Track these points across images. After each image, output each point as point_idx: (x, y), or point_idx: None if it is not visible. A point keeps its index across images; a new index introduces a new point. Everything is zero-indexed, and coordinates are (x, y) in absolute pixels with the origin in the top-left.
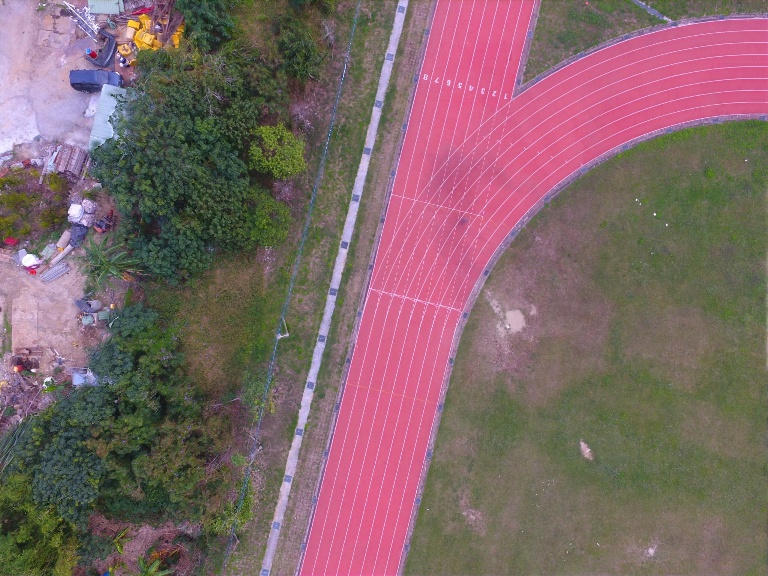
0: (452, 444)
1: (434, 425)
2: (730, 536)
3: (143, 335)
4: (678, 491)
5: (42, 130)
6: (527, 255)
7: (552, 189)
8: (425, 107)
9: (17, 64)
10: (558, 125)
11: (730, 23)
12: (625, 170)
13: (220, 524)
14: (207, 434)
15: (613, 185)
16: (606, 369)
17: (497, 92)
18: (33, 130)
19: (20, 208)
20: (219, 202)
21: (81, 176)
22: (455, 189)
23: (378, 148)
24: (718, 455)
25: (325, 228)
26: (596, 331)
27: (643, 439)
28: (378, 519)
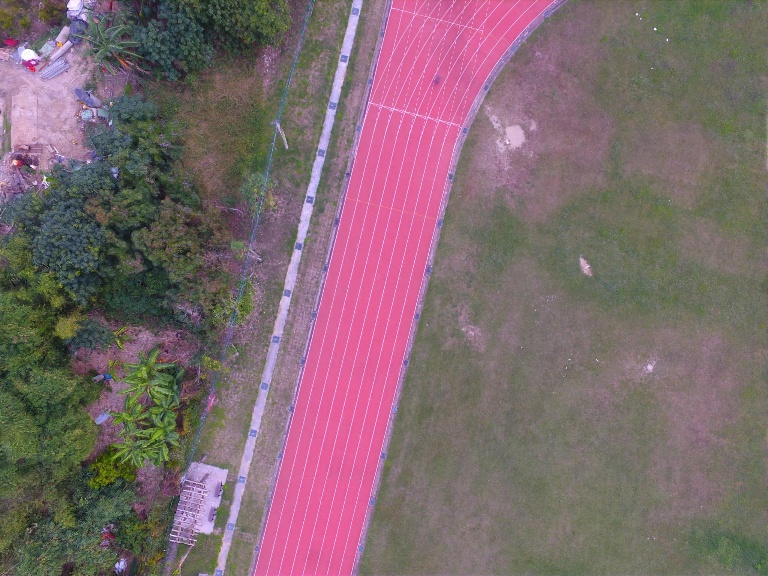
0: (451, 260)
1: (433, 241)
2: (729, 352)
3: None
4: (677, 307)
5: None
6: (527, 70)
7: (552, 3)
8: None
9: None
10: None
11: None
12: None
13: (219, 311)
14: (206, 224)
15: None
16: (606, 185)
17: None
18: None
19: (19, 7)
20: None
21: None
22: (455, 3)
23: None
24: (717, 271)
25: (325, 41)
26: (596, 146)
27: (642, 255)
28: (377, 334)
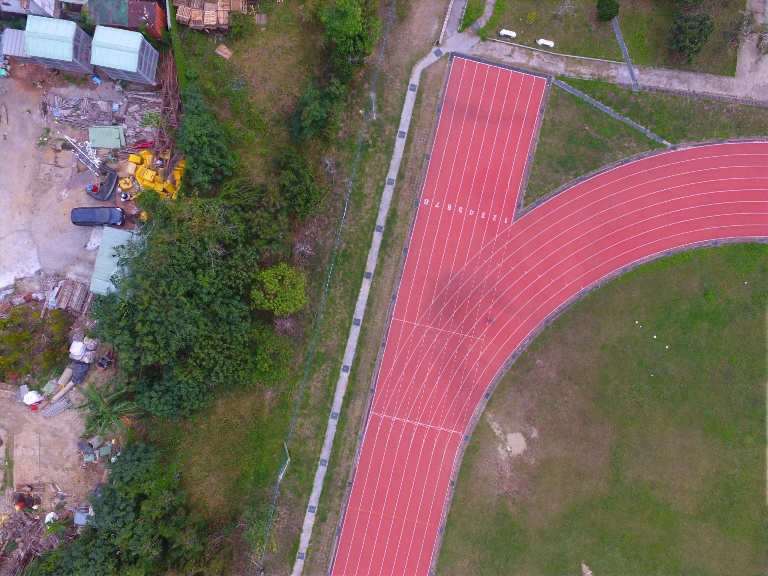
0: (454, 567)
1: (436, 548)
2: None
3: (145, 476)
4: None
5: (43, 264)
6: (528, 378)
7: (553, 312)
8: (426, 231)
9: (18, 198)
10: (558, 248)
11: (729, 147)
12: (625, 293)
13: None
14: (209, 575)
15: (613, 308)
16: (607, 491)
17: (497, 216)
18: (34, 264)
19: (22, 342)
20: (221, 352)
21: (83, 311)
22: (456, 313)
23: (379, 272)
24: None
25: (326, 353)
26: (597, 453)
27: (644, 561)
28: None
